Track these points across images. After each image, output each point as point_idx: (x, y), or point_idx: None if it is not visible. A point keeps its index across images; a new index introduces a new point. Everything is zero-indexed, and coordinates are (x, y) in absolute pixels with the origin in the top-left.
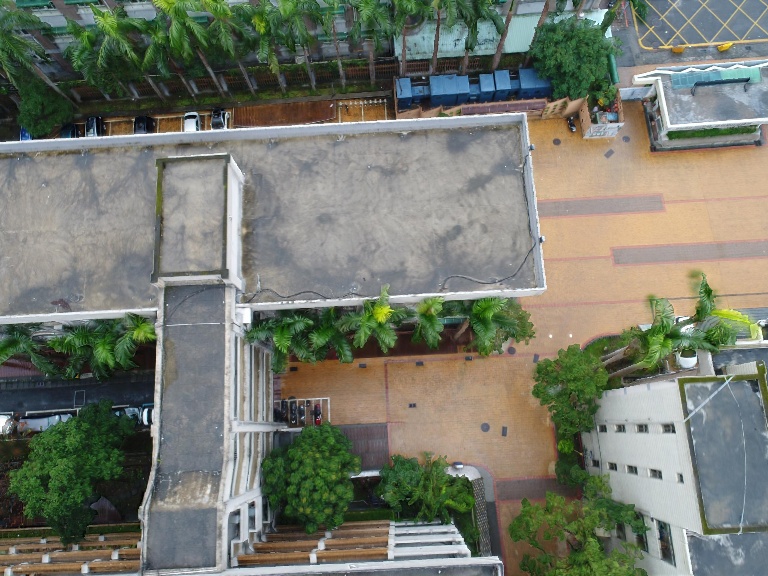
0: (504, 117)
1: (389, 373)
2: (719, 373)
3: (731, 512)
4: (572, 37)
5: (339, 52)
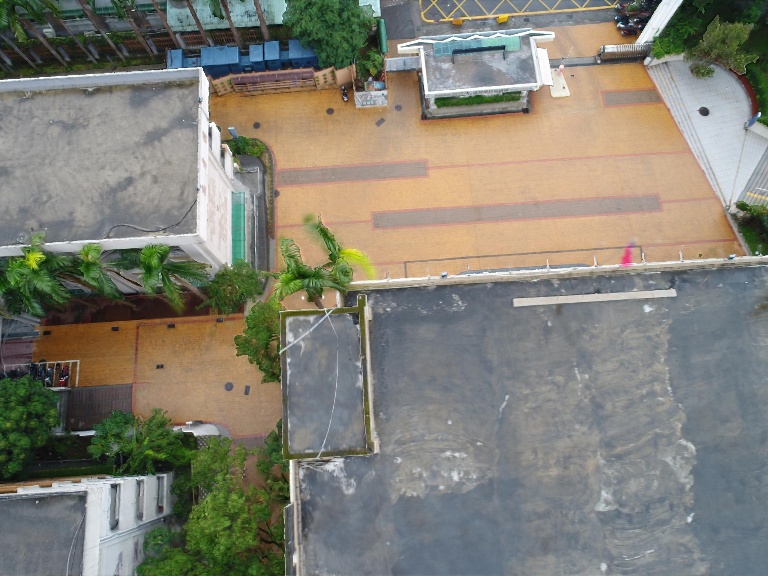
0: (182, 72)
1: (140, 335)
2: None
3: (315, 438)
4: (315, 4)
5: (127, 27)
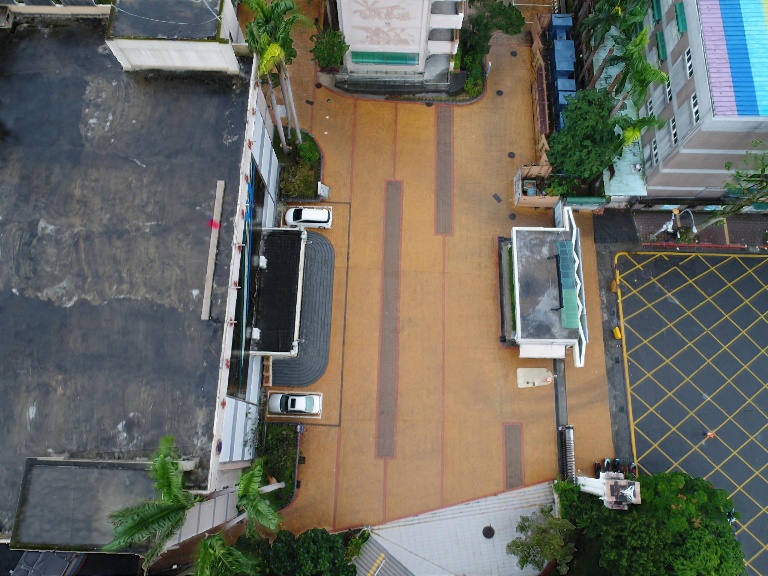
0: None
1: None
2: None
3: (127, 6)
4: None
5: None
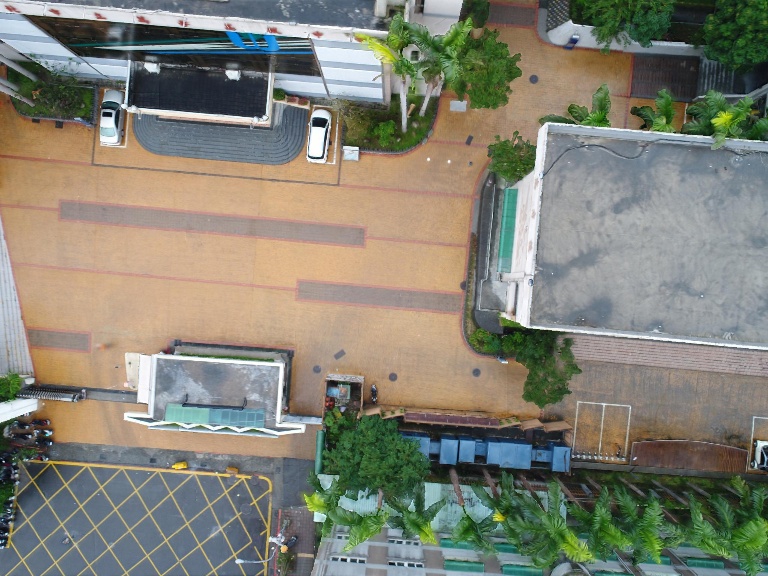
0: None
1: None
2: (393, 12)
3: None
4: None
5: None
